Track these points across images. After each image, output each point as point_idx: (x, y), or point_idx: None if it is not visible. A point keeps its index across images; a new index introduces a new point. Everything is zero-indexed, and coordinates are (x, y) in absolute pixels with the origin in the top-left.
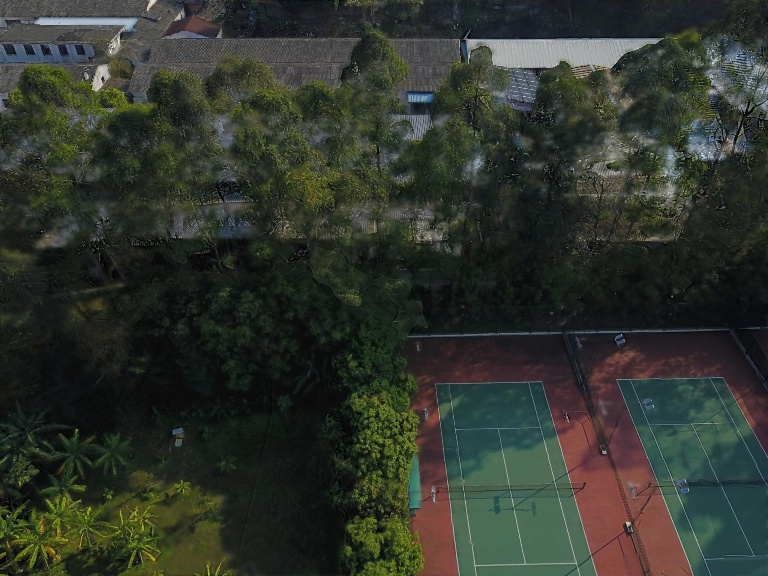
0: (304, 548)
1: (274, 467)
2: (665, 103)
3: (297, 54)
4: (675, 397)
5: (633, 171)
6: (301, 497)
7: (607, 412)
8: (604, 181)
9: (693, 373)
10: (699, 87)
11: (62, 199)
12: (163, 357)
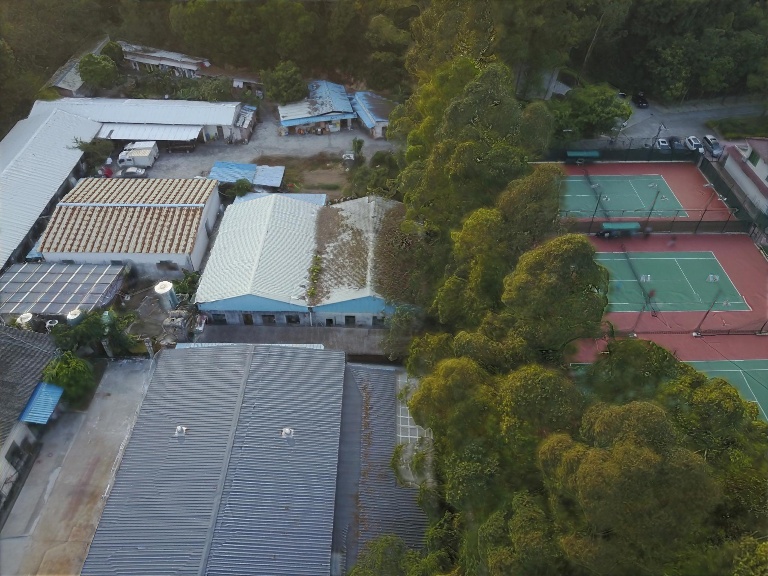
0: None
1: None
2: None
3: None
4: None
5: None
6: None
7: None
8: (395, 231)
9: None
10: None
11: None
12: None
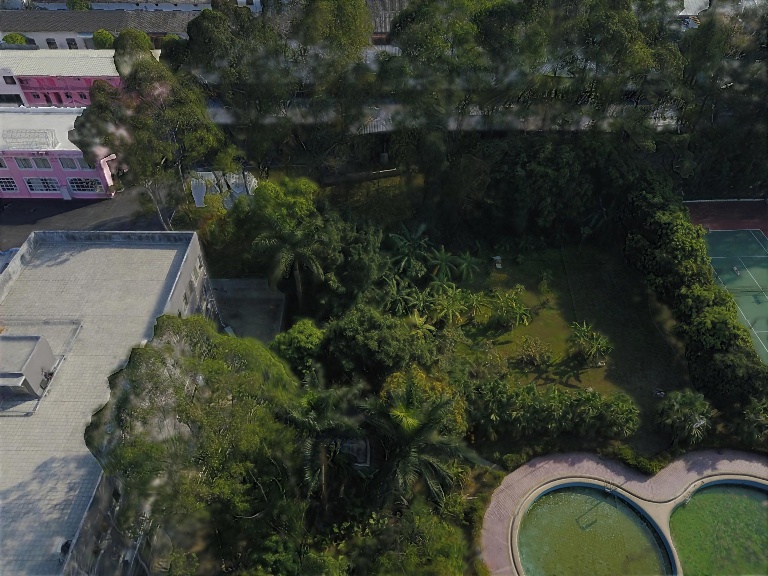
0: (625, 323)
1: (579, 279)
2: None
3: None
4: None
5: None
6: (608, 296)
7: None
8: None
9: None
10: None
11: (480, 59)
12: (501, 194)
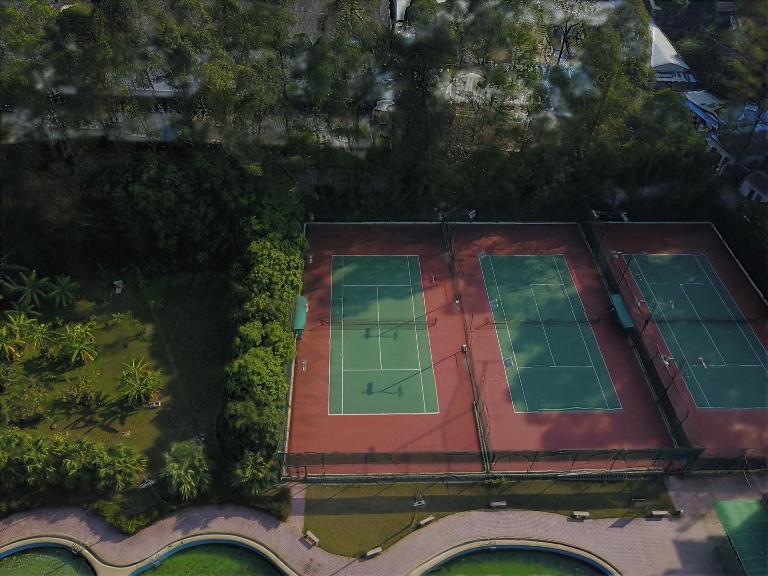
0: (212, 358)
1: (194, 308)
2: (494, 17)
3: (244, 2)
4: (522, 267)
5: (488, 82)
6: (214, 327)
7: (466, 276)
8: (480, 100)
9: (540, 251)
10: (529, 10)
11: (21, 72)
12: (105, 216)
